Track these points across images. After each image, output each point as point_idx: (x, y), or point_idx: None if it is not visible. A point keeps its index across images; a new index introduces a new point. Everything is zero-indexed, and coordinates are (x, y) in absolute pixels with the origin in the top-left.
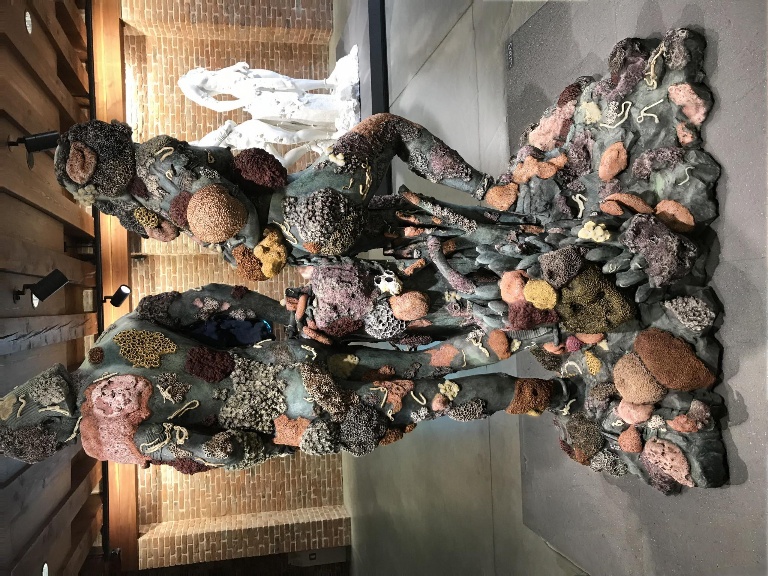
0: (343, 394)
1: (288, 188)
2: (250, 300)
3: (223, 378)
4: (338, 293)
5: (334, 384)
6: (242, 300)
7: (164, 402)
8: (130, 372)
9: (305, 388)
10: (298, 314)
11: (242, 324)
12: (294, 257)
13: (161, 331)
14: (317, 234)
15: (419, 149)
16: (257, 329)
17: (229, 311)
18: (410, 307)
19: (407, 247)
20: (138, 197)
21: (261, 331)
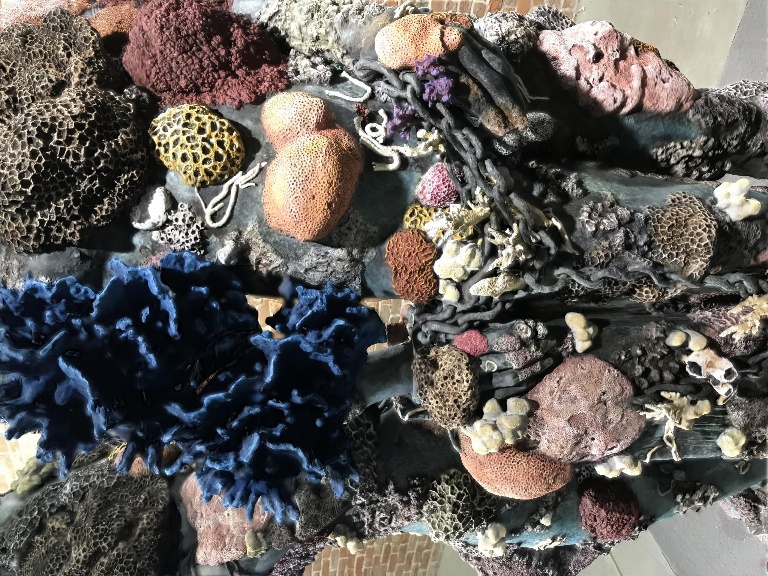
0: None
1: None
2: None
3: None
4: None
5: None
6: None
7: None
8: None
9: None
10: None
11: None
12: None
13: None
14: None
15: None
16: None
17: None
18: None
19: None
20: None
21: None
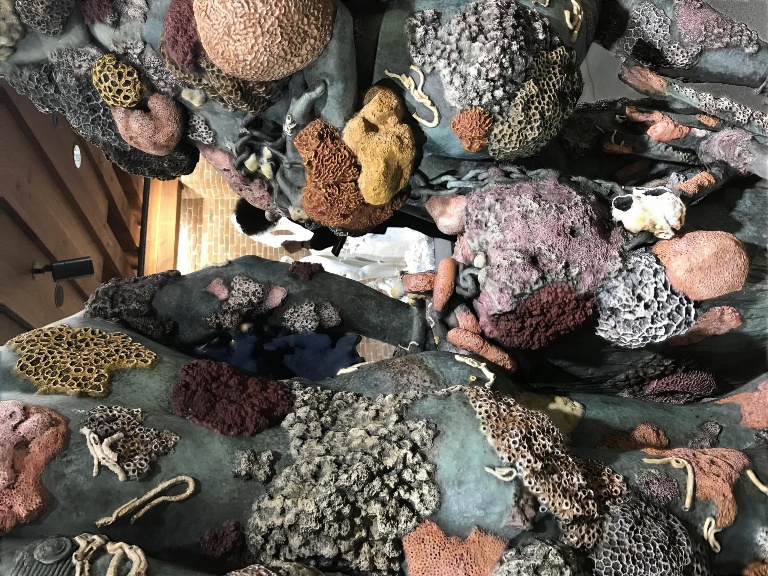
0: (583, 468)
1: (418, 0)
2: (328, 283)
3: (264, 427)
4: (539, 224)
5: (560, 436)
6: (311, 282)
7: (93, 473)
8: (21, 400)
9: (488, 440)
10: (439, 292)
11: (310, 339)
12: (425, 177)
13: (128, 333)
14: (491, 71)
15: (649, 1)
16: (342, 349)
17: (283, 310)
18: (712, 256)
19: (643, 185)
20: (100, 28)
21: (351, 354)
